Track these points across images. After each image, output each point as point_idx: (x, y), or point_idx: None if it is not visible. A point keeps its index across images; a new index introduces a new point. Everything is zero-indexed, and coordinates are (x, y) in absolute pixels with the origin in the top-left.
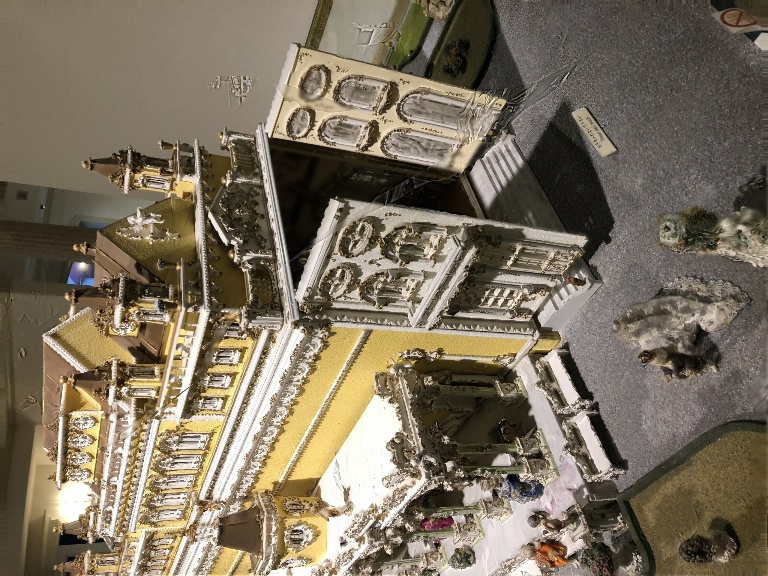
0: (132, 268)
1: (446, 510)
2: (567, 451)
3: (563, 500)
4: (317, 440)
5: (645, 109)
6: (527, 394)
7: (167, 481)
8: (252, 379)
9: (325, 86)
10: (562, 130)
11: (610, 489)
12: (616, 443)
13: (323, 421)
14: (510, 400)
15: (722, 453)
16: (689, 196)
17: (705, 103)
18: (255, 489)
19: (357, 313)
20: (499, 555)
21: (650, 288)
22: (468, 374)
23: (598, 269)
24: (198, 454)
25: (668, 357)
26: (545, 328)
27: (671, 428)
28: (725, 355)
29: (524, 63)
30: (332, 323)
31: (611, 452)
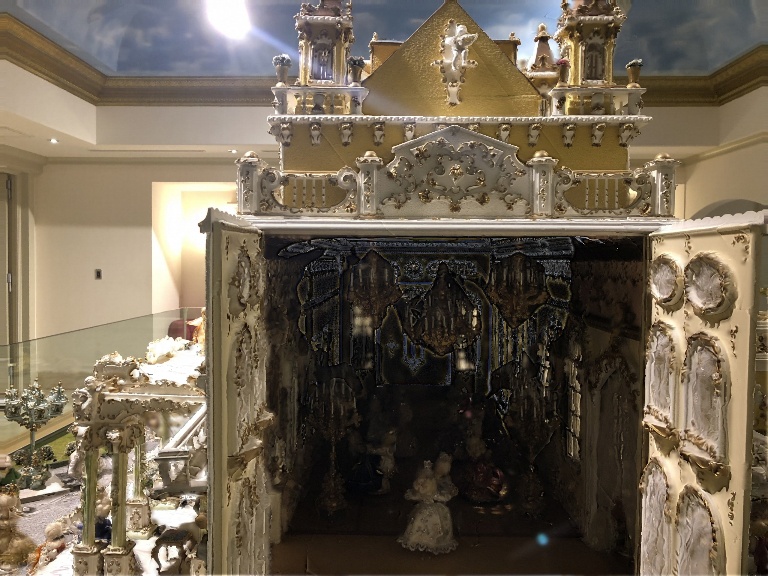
0: None
1: (137, 451)
2: None
3: None
4: None
5: None
6: None
7: None
8: None
9: None
10: None
11: None
12: None
13: None
14: None
15: None
16: None
17: None
18: None
19: None
20: None
21: None
22: None
23: None
24: None
25: None
26: None
27: None
28: None
29: None
30: None
31: None
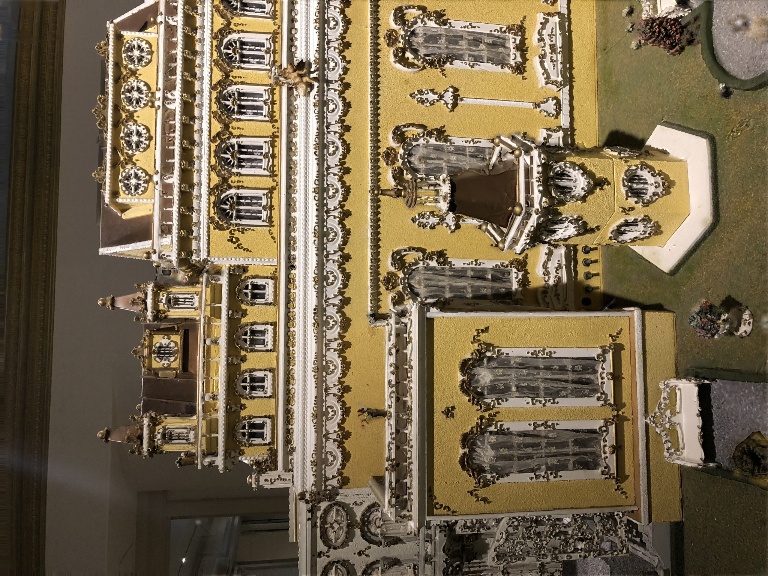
0: None
1: None
2: None
3: None
4: None
5: None
6: None
7: None
8: None
9: None
10: None
11: None
12: None
13: None
14: None
15: None
16: None
17: None
18: None
19: None
20: None
21: None
22: None
23: None
24: None
25: None
26: None
27: None
28: None
29: None
30: None
31: None
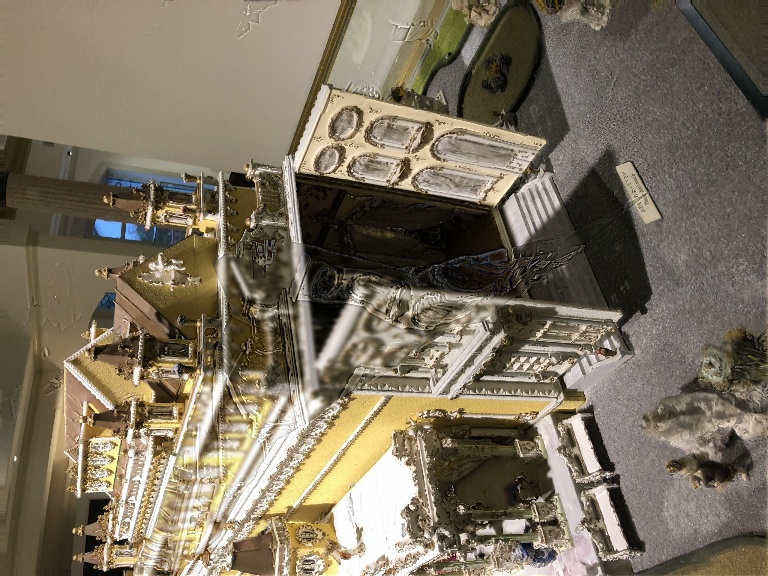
0: (152, 315)
1: (457, 564)
2: (584, 527)
3: (576, 572)
4: (332, 476)
5: (696, 180)
6: (547, 455)
7: None
8: None
9: (356, 126)
10: (604, 180)
11: (625, 568)
12: (635, 522)
13: (339, 462)
14: (529, 459)
15: (745, 563)
16: (735, 287)
17: (763, 190)
18: (269, 511)
19: (378, 378)
20: None
21: (684, 373)
22: (488, 428)
23: (631, 338)
24: None
25: (698, 467)
26: (570, 389)
27: (693, 523)
28: (758, 465)
29: (568, 96)
30: (352, 391)
31: (629, 529)
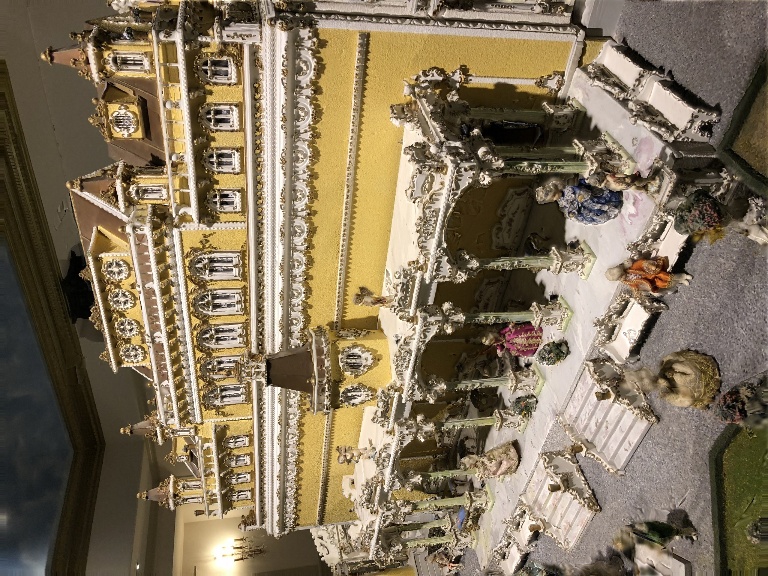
0: None
1: (507, 260)
2: (635, 117)
3: None
4: (359, 246)
5: None
6: (585, 109)
7: (215, 336)
8: (255, 138)
9: None
10: None
11: (704, 149)
12: (701, 96)
13: (357, 210)
14: (565, 121)
15: None
16: None
17: None
18: None
19: None
20: (591, 319)
21: None
22: None
23: None
24: (237, 288)
25: None
26: (592, 30)
27: (761, 13)
28: None
29: None
30: (317, 21)
31: None
